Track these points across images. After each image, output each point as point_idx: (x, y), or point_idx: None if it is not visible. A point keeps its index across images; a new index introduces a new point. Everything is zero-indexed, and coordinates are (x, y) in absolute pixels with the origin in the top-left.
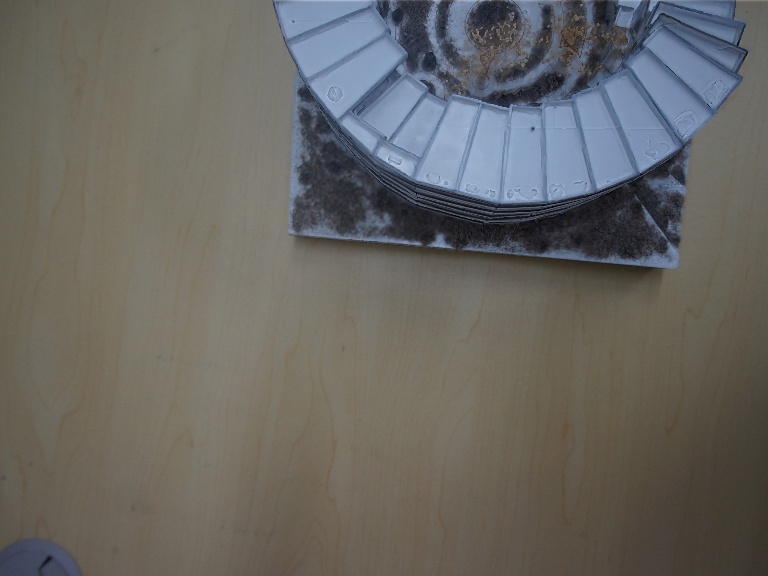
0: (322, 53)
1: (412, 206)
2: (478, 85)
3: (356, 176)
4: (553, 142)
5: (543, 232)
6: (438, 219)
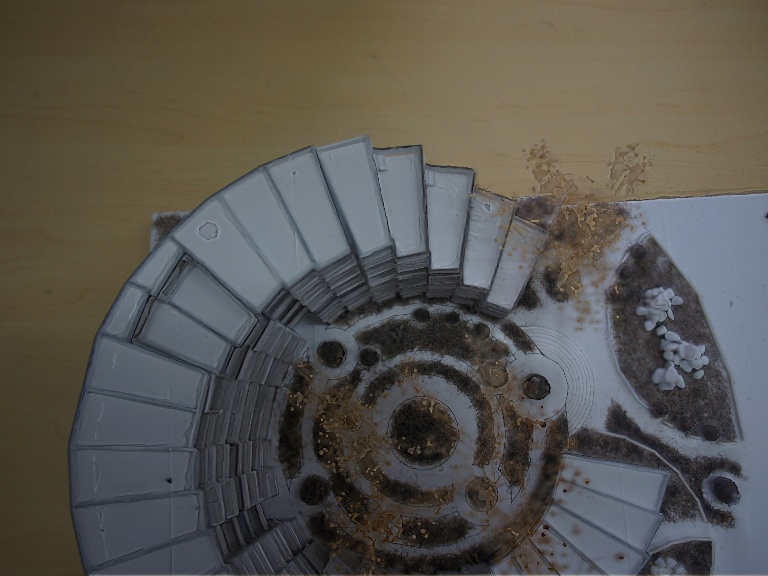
0: (257, 210)
1: None
2: None
3: None
4: (153, 509)
5: None
6: None
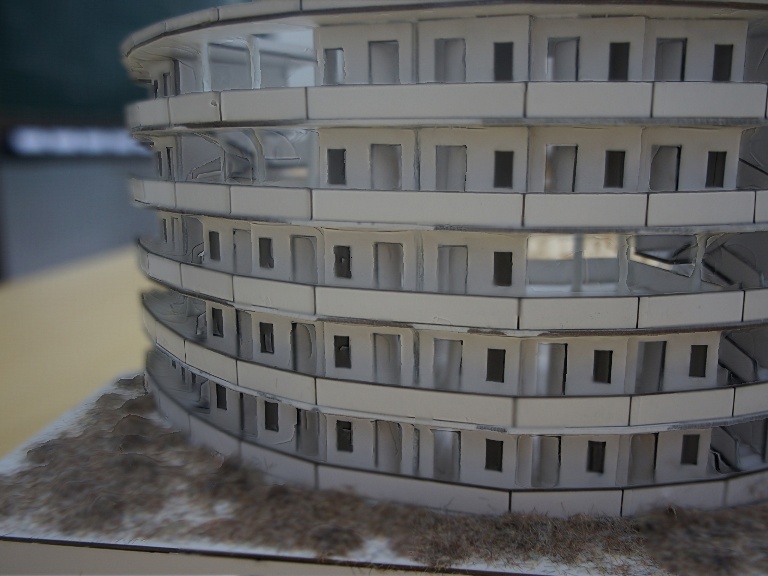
0: None
1: (303, 485)
2: None
3: (174, 453)
4: None
5: (702, 538)
6: (374, 508)
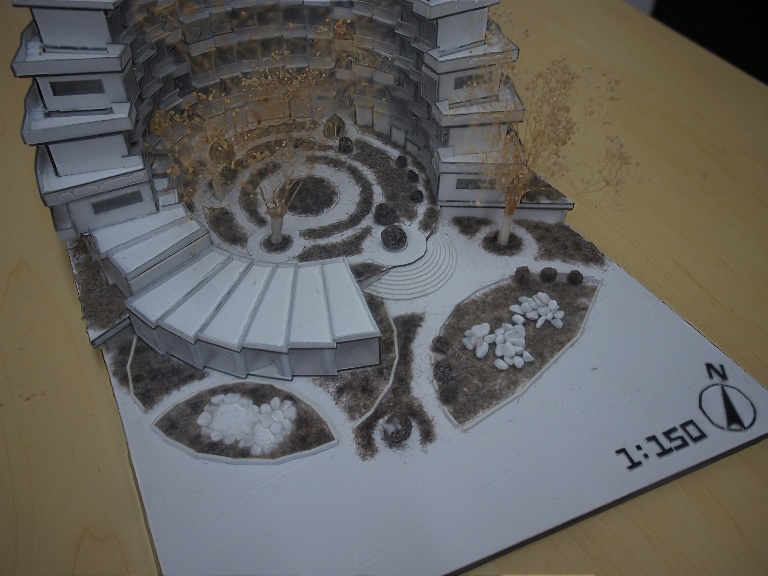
0: None
1: None
2: (290, 152)
3: None
4: None
5: None
6: None
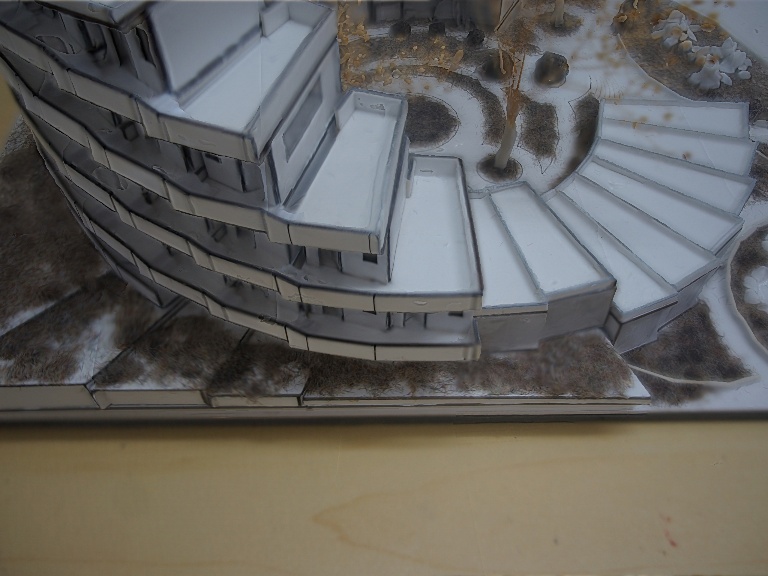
0: None
1: None
2: None
3: None
4: None
5: (33, 171)
6: None
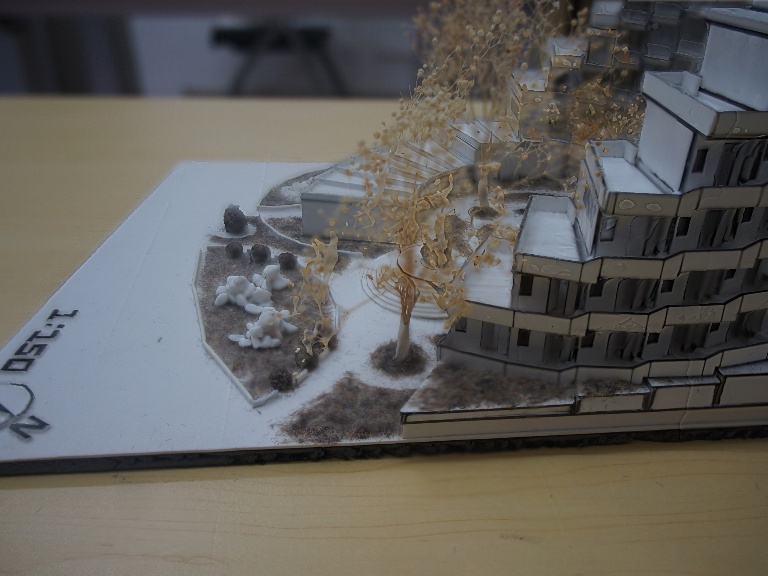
0: None
1: None
2: None
3: None
4: None
5: None
6: None
